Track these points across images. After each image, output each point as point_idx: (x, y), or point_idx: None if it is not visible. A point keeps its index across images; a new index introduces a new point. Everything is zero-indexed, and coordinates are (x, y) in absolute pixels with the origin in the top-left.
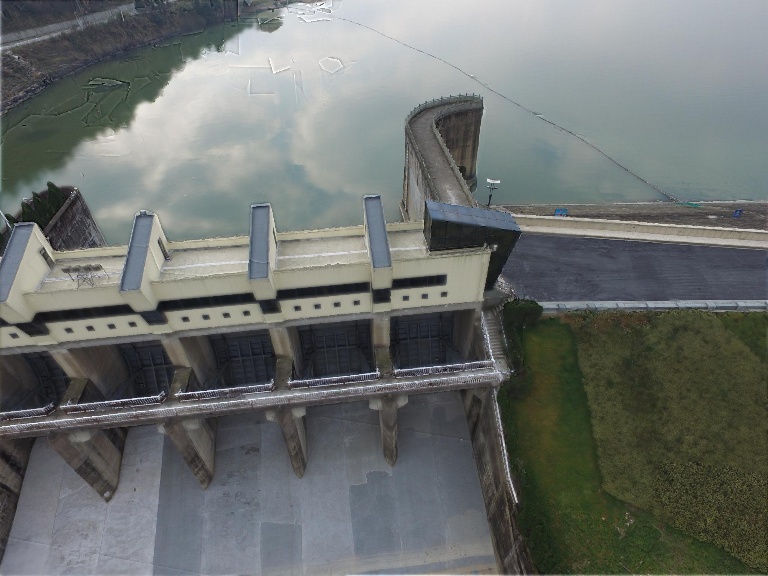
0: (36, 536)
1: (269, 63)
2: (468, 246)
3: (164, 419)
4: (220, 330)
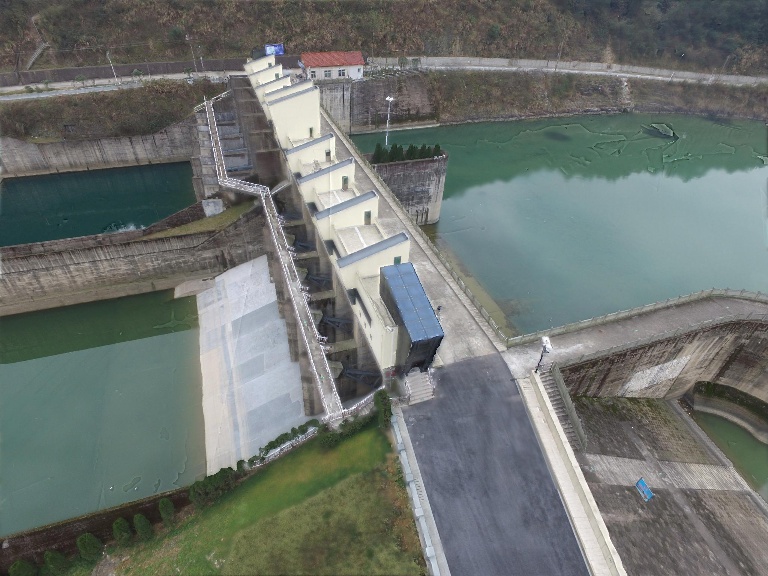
0: (254, 268)
1: None
2: None
3: None
4: None
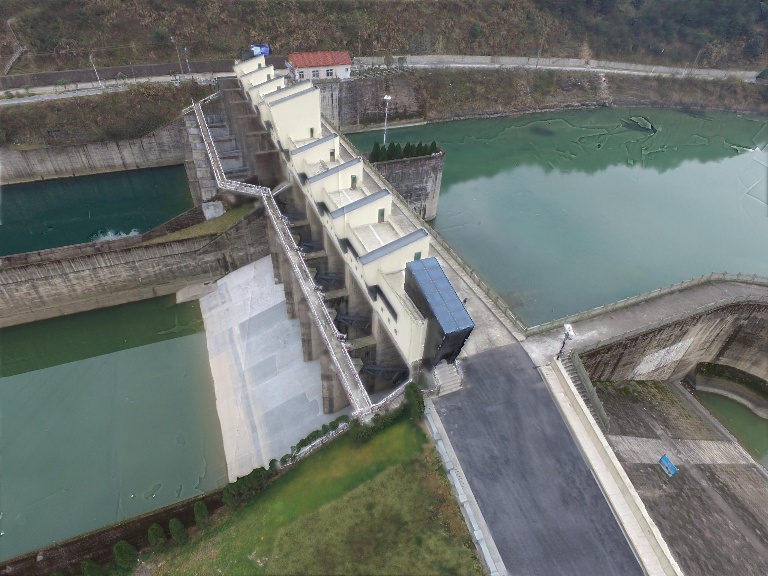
0: (256, 270)
1: None
2: (420, 310)
3: None
4: None
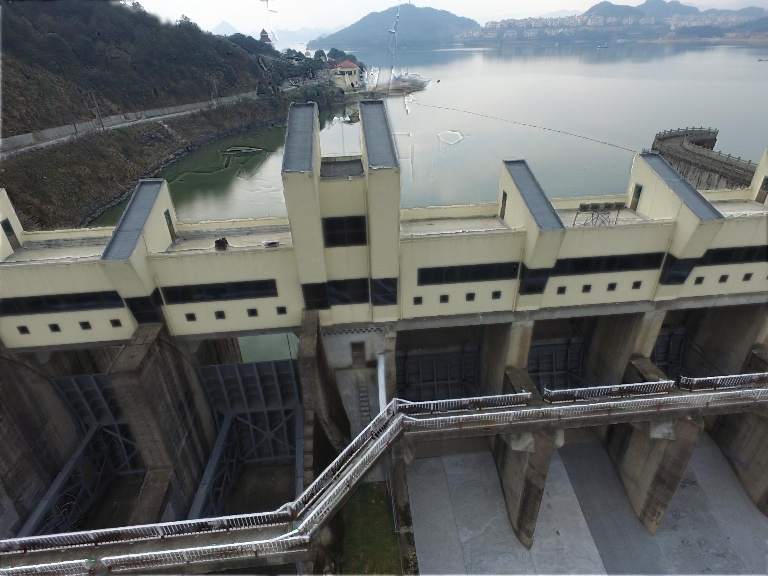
0: None
1: None
2: None
3: (690, 411)
4: (720, 301)
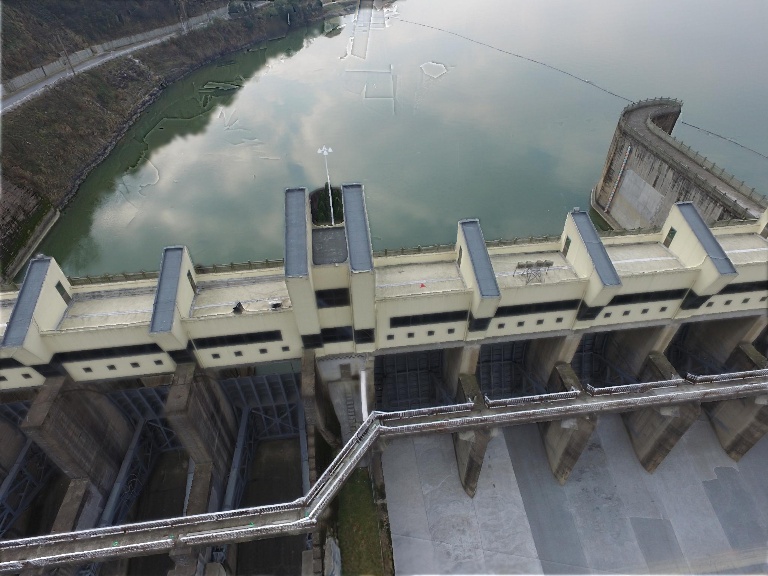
0: (415, 532)
1: (390, 67)
2: None
3: (589, 413)
4: (624, 326)
